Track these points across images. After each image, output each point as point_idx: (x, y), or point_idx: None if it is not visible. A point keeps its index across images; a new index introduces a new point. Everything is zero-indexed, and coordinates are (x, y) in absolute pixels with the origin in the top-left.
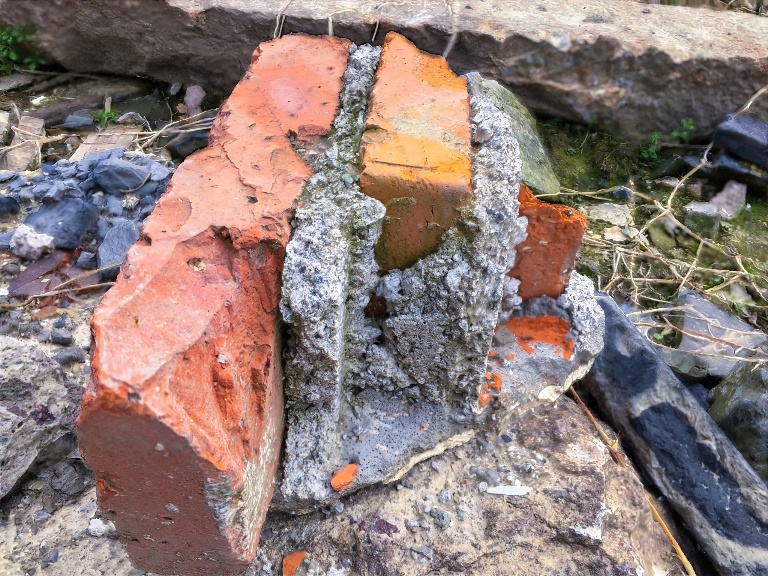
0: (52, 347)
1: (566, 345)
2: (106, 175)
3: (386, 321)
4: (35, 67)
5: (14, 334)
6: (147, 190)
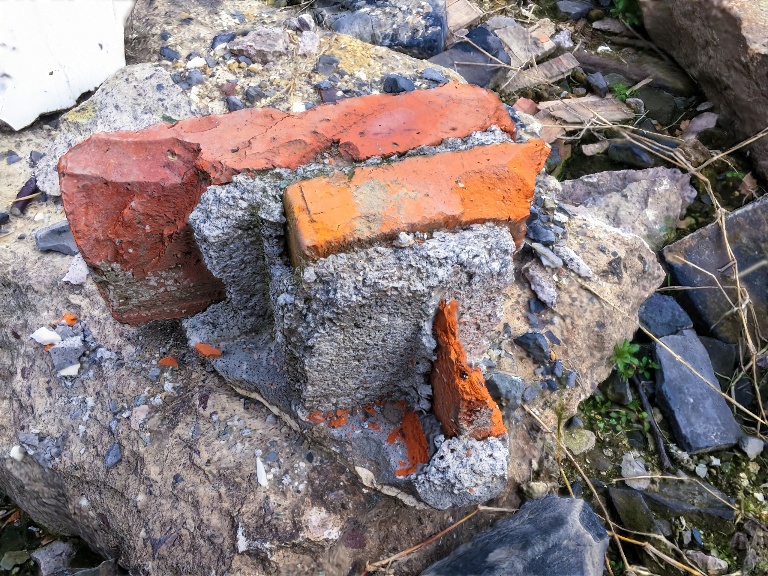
0: None
1: (411, 468)
2: None
3: (270, 292)
4: (629, 23)
5: None
6: None
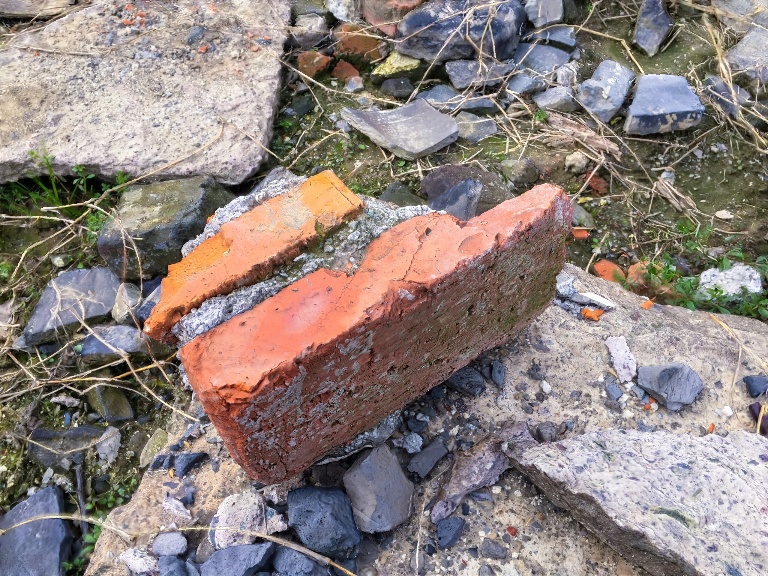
0: (499, 574)
1: None
2: None
3: None
4: None
5: None
6: None
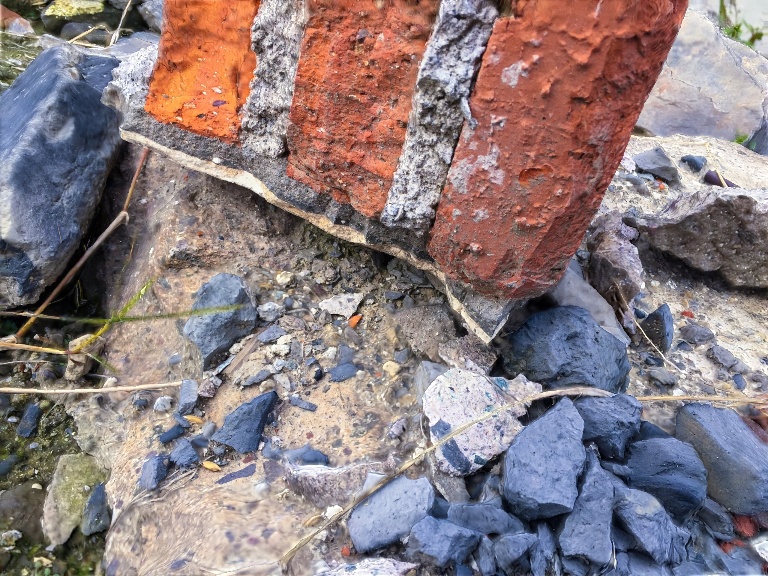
0: None
1: None
2: None
3: None
4: None
5: None
6: None
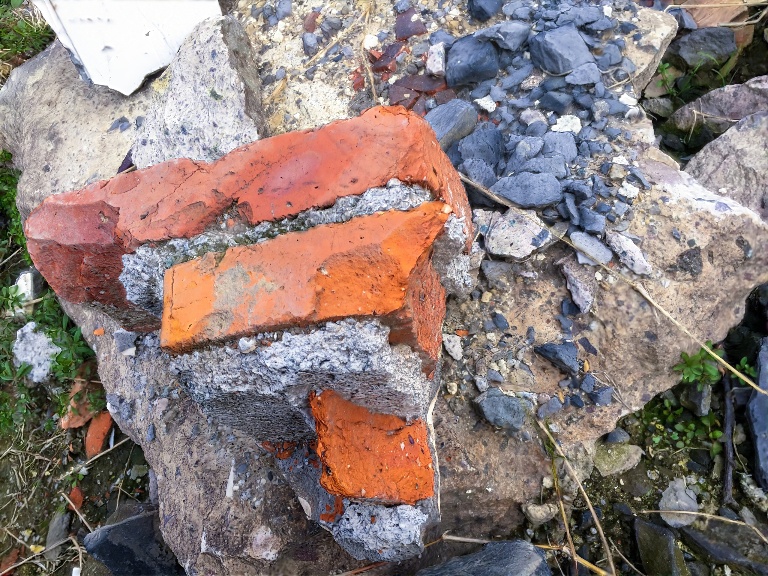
0: None
1: (333, 515)
2: (537, 45)
3: None
4: None
5: (357, 114)
6: (550, 84)
